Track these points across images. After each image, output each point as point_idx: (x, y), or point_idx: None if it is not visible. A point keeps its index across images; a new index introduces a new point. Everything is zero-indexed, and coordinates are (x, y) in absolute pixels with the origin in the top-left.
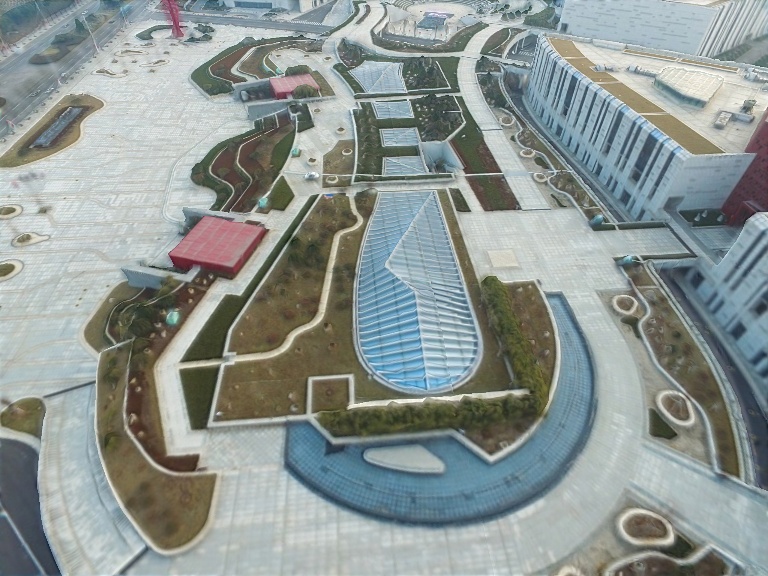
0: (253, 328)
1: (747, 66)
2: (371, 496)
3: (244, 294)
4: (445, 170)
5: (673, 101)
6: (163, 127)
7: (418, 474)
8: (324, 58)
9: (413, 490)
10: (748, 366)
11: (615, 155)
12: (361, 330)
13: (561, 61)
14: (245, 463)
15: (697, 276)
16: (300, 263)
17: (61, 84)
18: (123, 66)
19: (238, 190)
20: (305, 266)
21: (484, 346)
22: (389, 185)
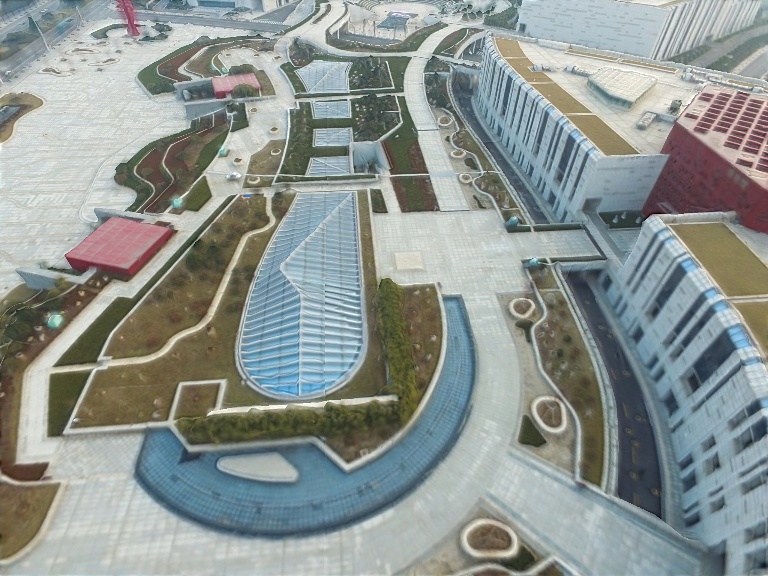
0: (136, 332)
1: (686, 67)
2: (216, 506)
3: (136, 297)
4: (376, 171)
5: (602, 101)
6: (98, 126)
7: (269, 483)
8: (274, 57)
9: (261, 500)
10: (644, 371)
11: (543, 156)
12: (245, 334)
13: (500, 61)
14: (94, 472)
15: (607, 279)
16: (198, 265)
17: (3, 83)
18: (71, 65)
19: (158, 190)
20: (204, 268)
21: (368, 350)
22: (310, 186)
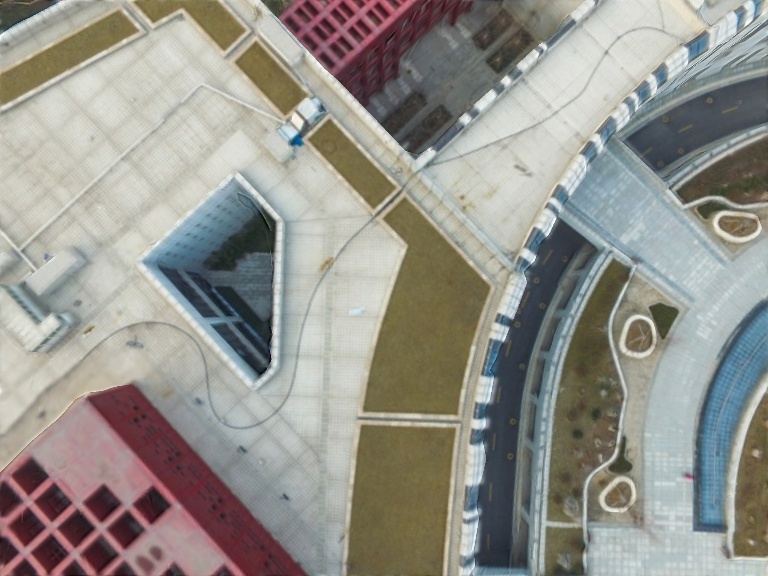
0: None
1: None
2: None
3: None
4: None
5: None
6: None
7: None
8: None
9: None
10: None
11: None
12: None
13: None
14: None
15: None
16: None
17: None
18: None
19: None
20: None
21: None
22: None
